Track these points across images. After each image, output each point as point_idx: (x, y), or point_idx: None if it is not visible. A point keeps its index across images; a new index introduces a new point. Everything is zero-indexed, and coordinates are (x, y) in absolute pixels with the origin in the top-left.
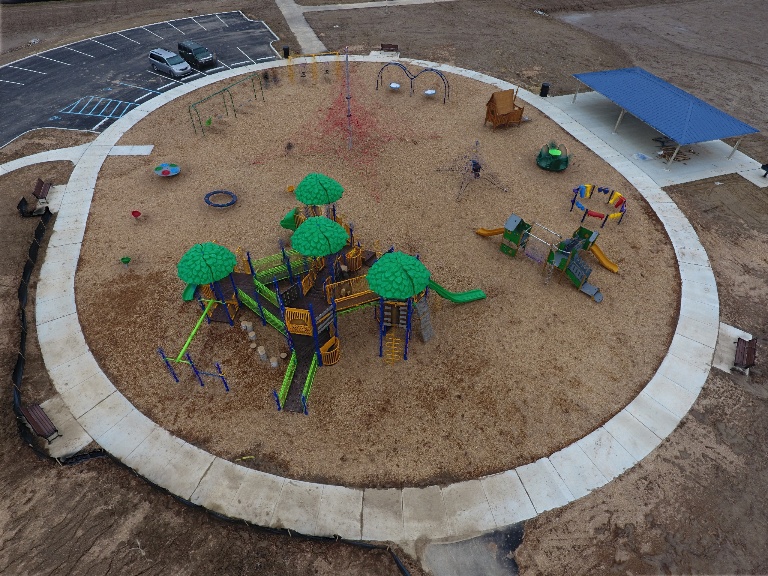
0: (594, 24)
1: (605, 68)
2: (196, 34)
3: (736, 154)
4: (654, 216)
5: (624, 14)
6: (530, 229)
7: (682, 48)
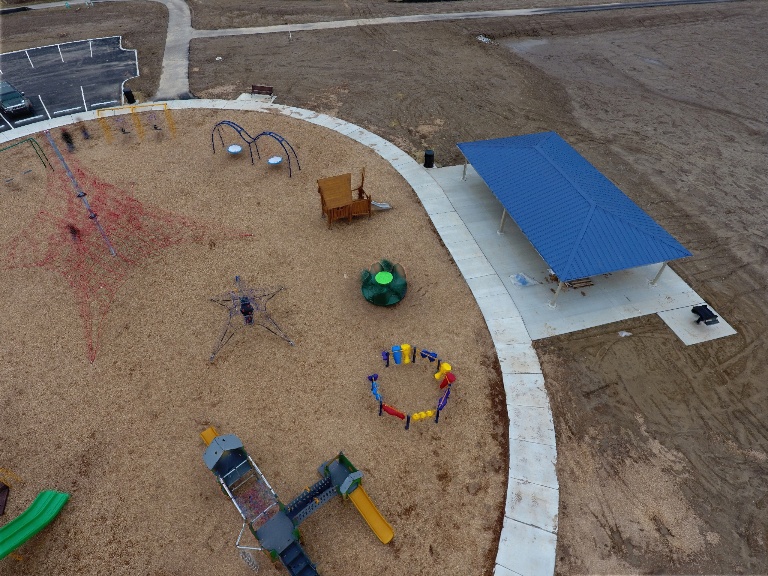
0: (546, 54)
1: (529, 122)
2: (46, 67)
3: (665, 276)
4: (500, 404)
5: (588, 41)
6: (247, 462)
7: (645, 90)
